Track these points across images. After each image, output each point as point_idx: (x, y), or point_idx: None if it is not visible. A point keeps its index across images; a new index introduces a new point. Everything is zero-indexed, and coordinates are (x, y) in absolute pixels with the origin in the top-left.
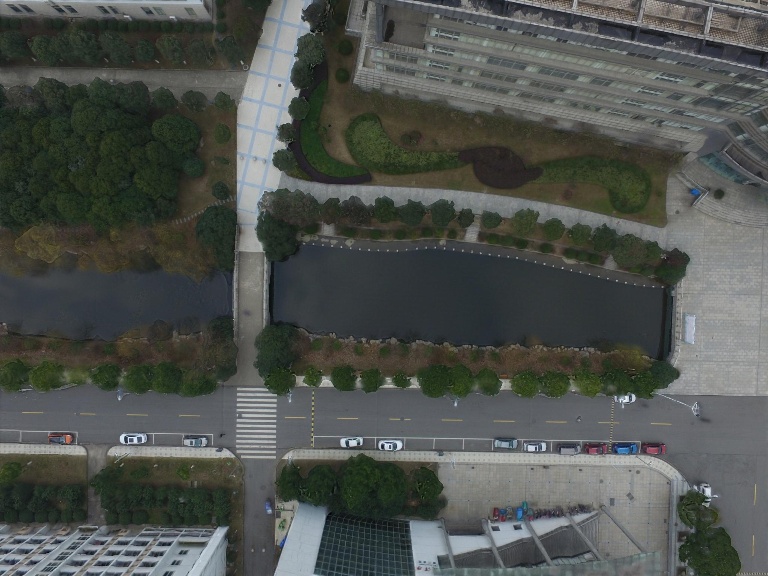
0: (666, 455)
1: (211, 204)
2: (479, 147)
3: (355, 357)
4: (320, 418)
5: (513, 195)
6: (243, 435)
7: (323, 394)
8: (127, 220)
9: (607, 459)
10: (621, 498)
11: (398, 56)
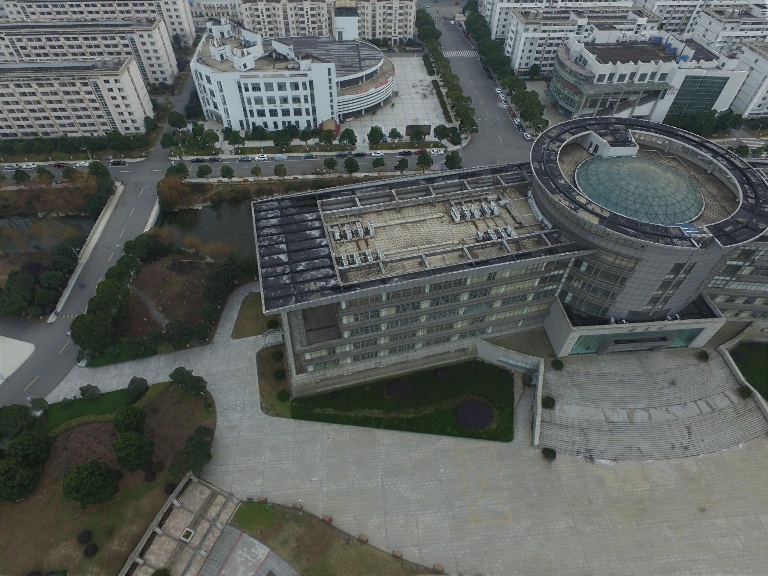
0: None
1: None
2: None
3: None
4: None
5: None
6: (762, 144)
7: None
8: None
9: None
10: None
11: None
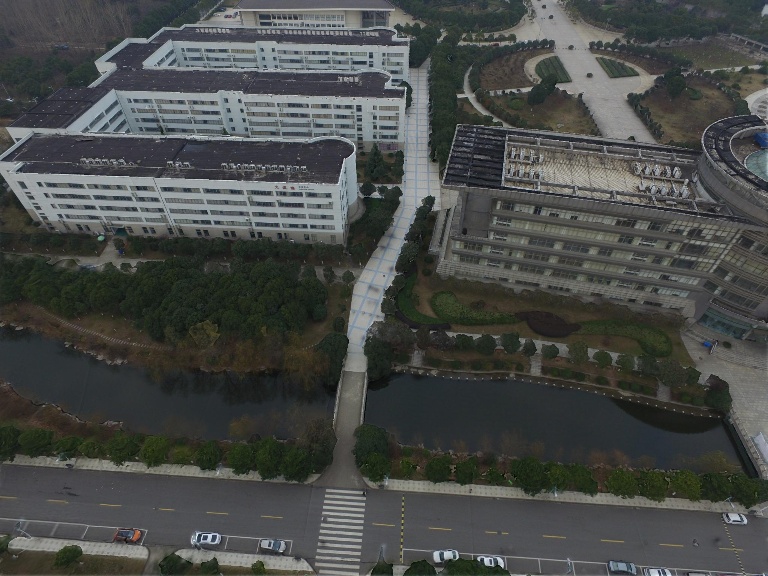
0: None
1: None
2: (529, 311)
3: None
4: (410, 527)
5: (563, 342)
6: (325, 543)
7: (413, 500)
8: None
9: None
10: None
11: (470, 246)
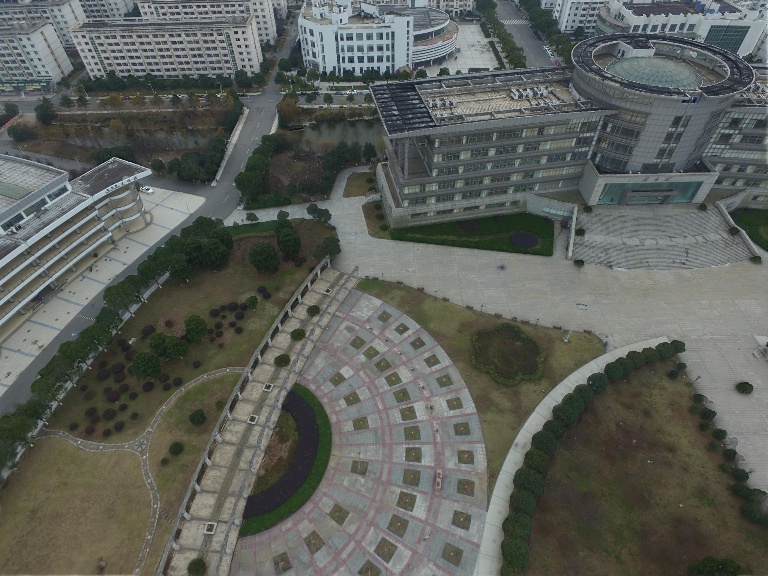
0: None
1: None
2: None
3: None
4: None
5: None
6: None
7: None
8: None
9: None
10: None
11: None
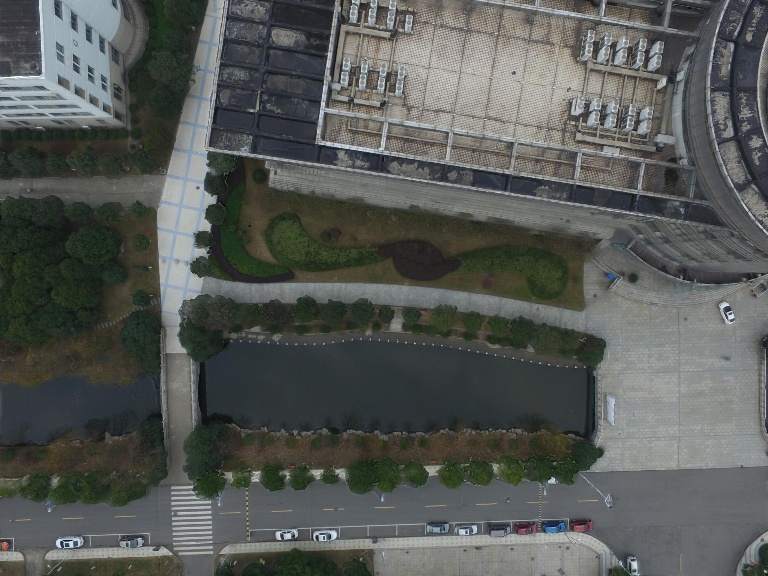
0: (594, 530)
1: (136, 308)
2: (398, 241)
3: (287, 450)
4: (255, 512)
5: (434, 286)
6: (179, 533)
7: (256, 489)
8: (47, 335)
9: (537, 537)
10: (552, 574)
11: None
